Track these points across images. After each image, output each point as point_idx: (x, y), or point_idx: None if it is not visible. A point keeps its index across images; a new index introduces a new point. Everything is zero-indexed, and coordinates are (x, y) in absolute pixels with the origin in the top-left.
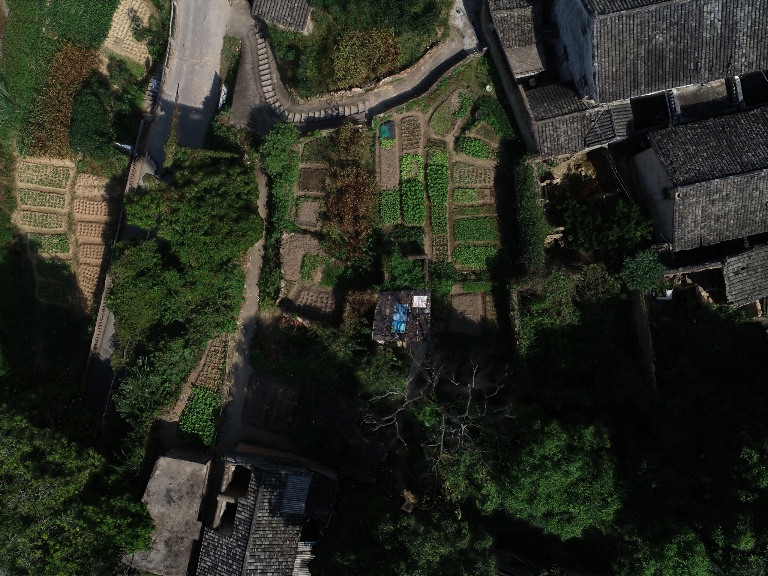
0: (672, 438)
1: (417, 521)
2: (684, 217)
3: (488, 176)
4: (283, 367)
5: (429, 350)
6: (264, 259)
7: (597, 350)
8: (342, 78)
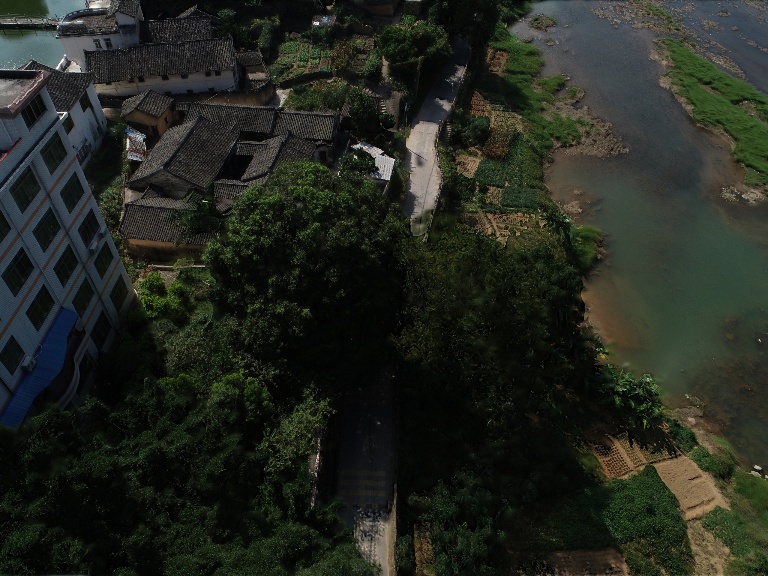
0: None
1: None
2: None
3: None
4: None
5: None
6: None
7: None
8: None
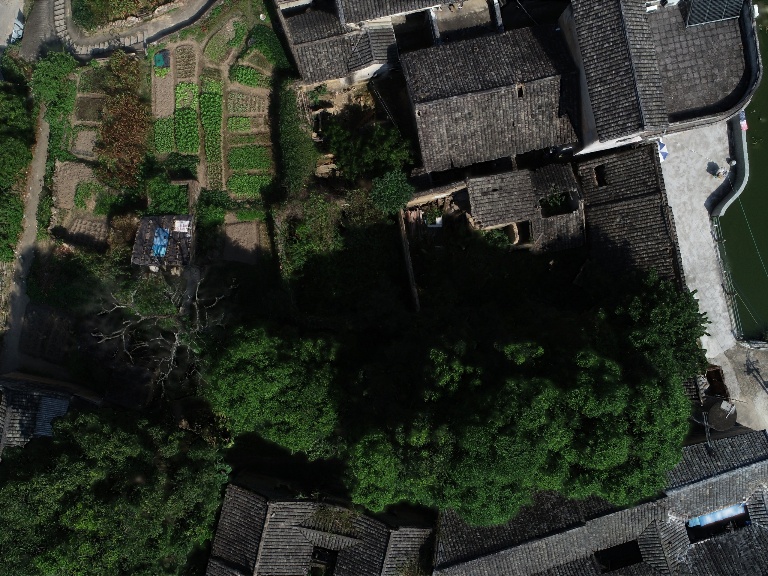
0: (393, 350)
1: (105, 422)
2: (429, 137)
3: (262, 105)
4: (55, 294)
5: (200, 277)
6: (43, 189)
7: (362, 276)
8: (117, 7)
